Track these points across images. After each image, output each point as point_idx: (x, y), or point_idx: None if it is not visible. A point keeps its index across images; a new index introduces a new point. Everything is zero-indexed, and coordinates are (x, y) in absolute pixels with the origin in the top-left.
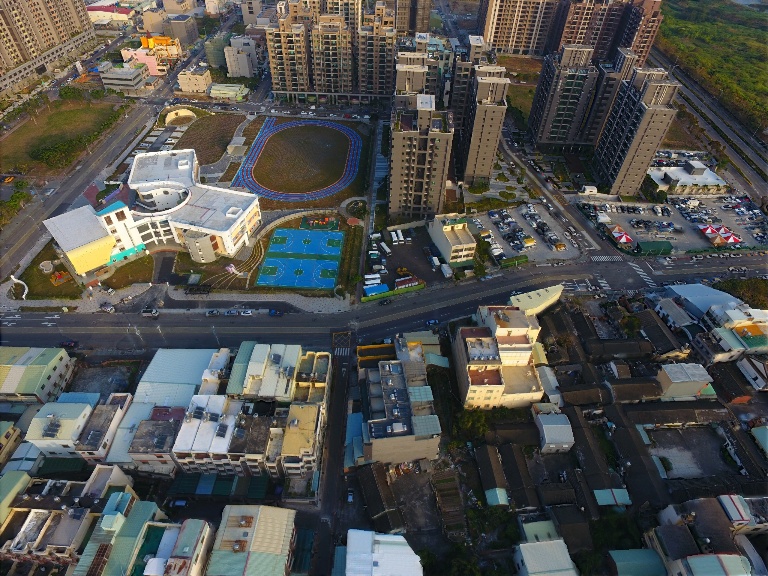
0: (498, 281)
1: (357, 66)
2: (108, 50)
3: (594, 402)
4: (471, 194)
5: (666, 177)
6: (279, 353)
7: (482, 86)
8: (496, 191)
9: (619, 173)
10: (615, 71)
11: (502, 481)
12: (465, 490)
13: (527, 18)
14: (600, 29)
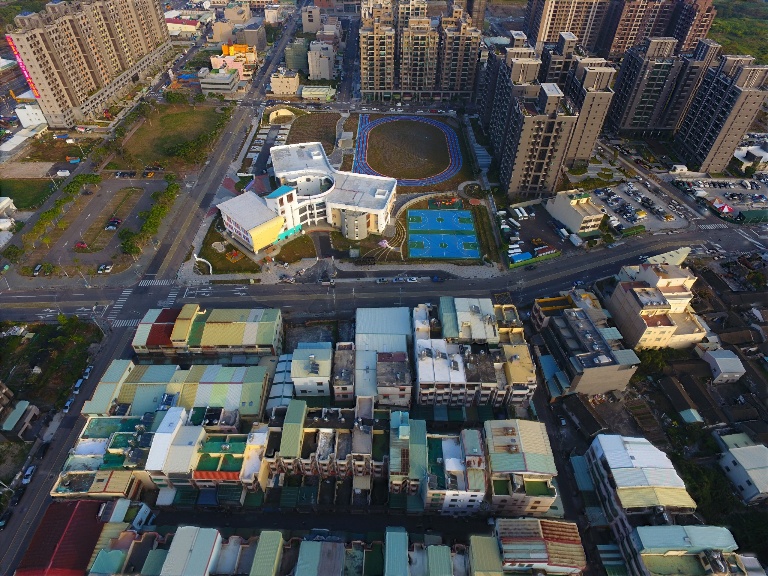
0: (623, 248)
1: (440, 65)
2: (187, 59)
3: (747, 341)
4: (572, 175)
5: (749, 155)
6: (475, 305)
7: (589, 75)
8: (594, 172)
9: (710, 152)
10: (696, 60)
11: (692, 404)
12: (658, 414)
13: (580, 17)
14: (652, 25)
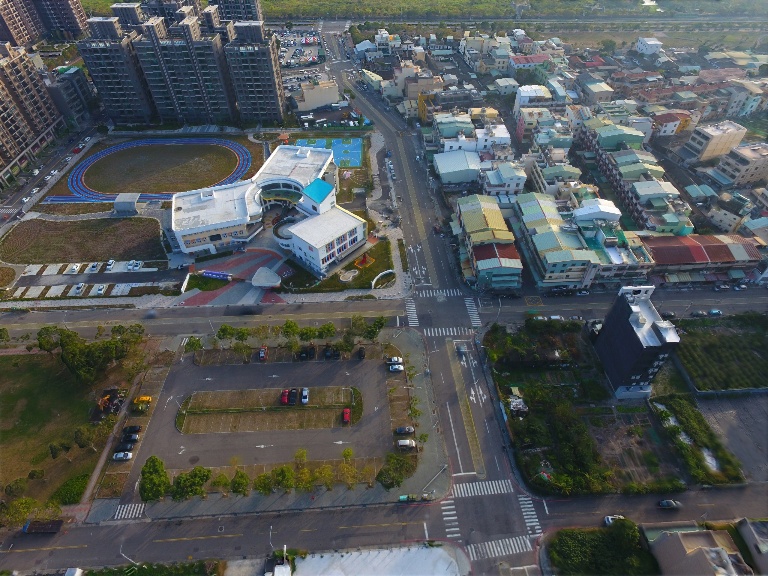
0: (349, 93)
1: None
2: None
3: None
4: None
5: None
6: None
7: None
8: None
9: None
10: None
11: None
12: None
13: None
14: (24, 6)
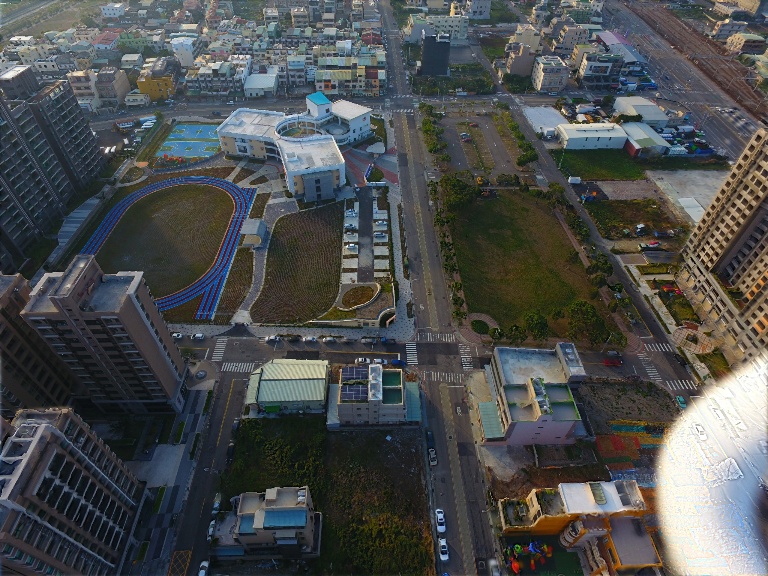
0: None
1: None
2: None
3: None
4: None
5: None
6: (208, 70)
7: None
8: None
9: None
10: None
11: None
12: None
13: None
14: None
